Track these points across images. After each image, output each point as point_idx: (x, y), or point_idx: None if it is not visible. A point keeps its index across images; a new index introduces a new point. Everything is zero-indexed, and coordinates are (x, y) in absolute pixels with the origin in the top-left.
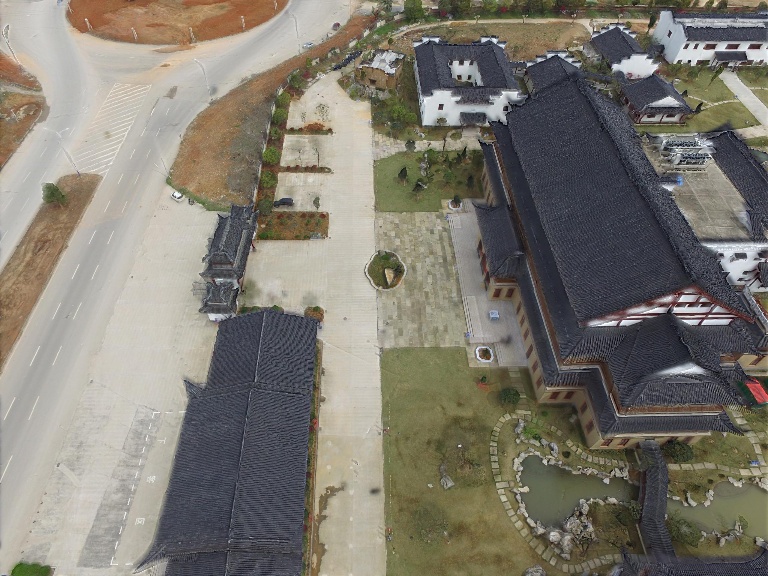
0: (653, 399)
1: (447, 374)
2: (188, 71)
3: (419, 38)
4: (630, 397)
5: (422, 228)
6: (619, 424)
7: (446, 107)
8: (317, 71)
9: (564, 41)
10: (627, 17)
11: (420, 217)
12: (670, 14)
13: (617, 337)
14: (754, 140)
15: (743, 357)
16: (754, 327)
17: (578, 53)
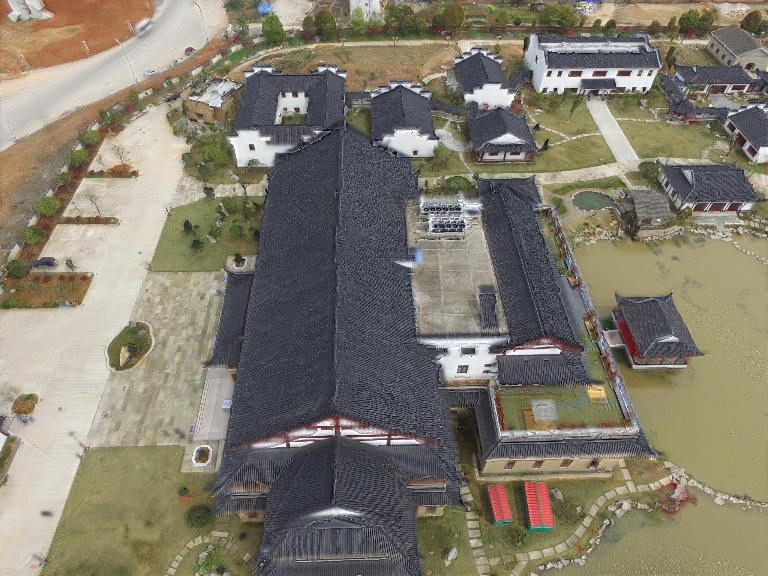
0: (296, 550)
1: (149, 482)
2: (7, 103)
3: (274, 64)
4: (271, 546)
5: (193, 292)
6: (278, 571)
7: (258, 147)
8: (147, 103)
9: (431, 66)
10: (509, 38)
11: (196, 278)
12: (537, 38)
13: (286, 461)
14: (603, 181)
15: (489, 463)
16: (491, 432)
17: (442, 80)
